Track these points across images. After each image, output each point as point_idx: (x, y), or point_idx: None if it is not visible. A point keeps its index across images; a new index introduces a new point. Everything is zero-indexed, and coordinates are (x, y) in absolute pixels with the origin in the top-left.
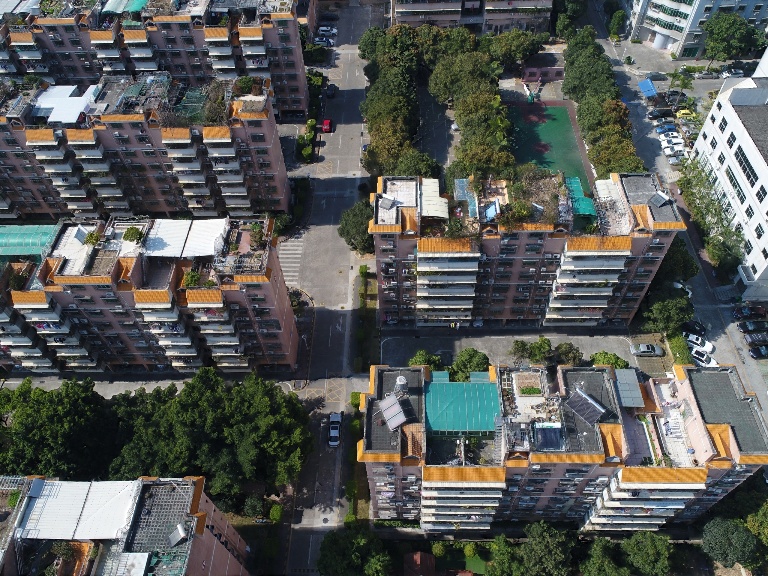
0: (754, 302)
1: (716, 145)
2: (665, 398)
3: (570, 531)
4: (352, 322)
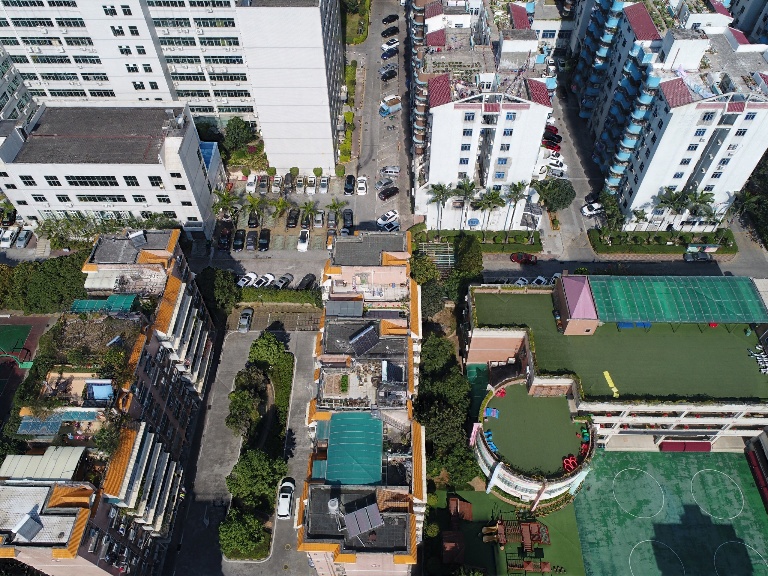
0: (214, 234)
1: (43, 197)
2: (346, 291)
3: (416, 409)
4: None
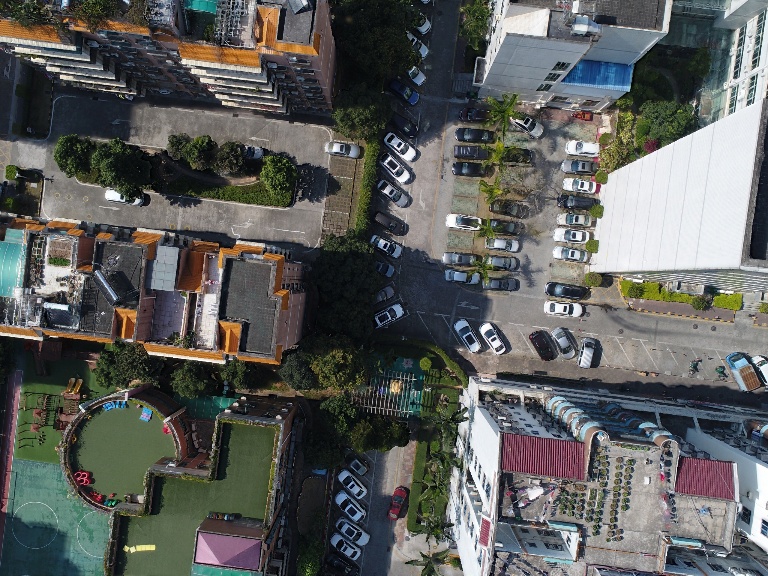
0: None
1: None
2: (220, 272)
3: None
4: (22, 68)
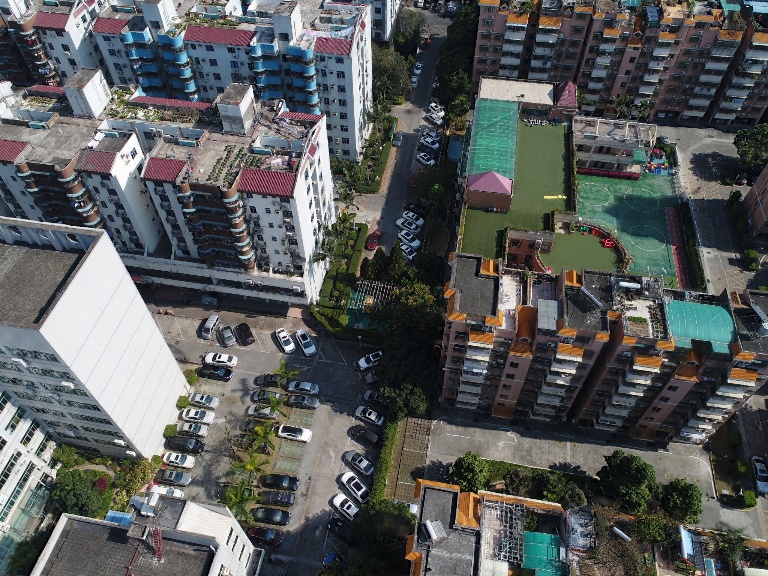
0: None
1: None
2: (505, 323)
3: None
4: None
